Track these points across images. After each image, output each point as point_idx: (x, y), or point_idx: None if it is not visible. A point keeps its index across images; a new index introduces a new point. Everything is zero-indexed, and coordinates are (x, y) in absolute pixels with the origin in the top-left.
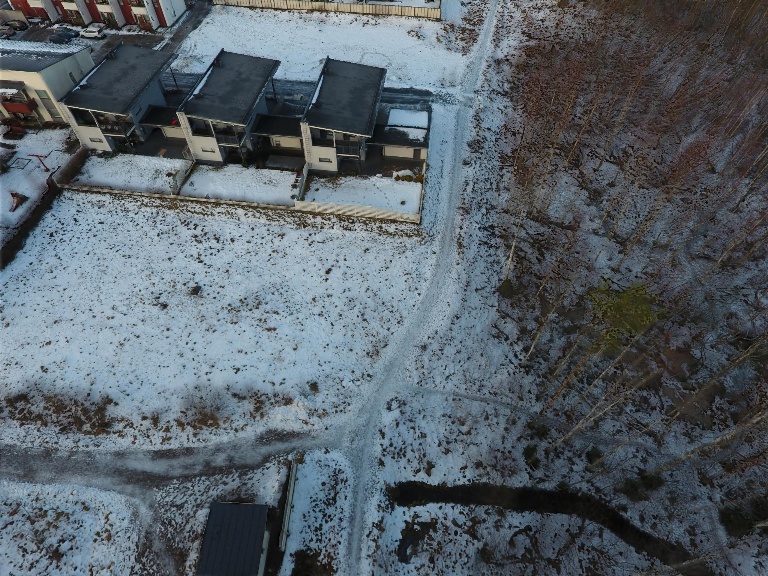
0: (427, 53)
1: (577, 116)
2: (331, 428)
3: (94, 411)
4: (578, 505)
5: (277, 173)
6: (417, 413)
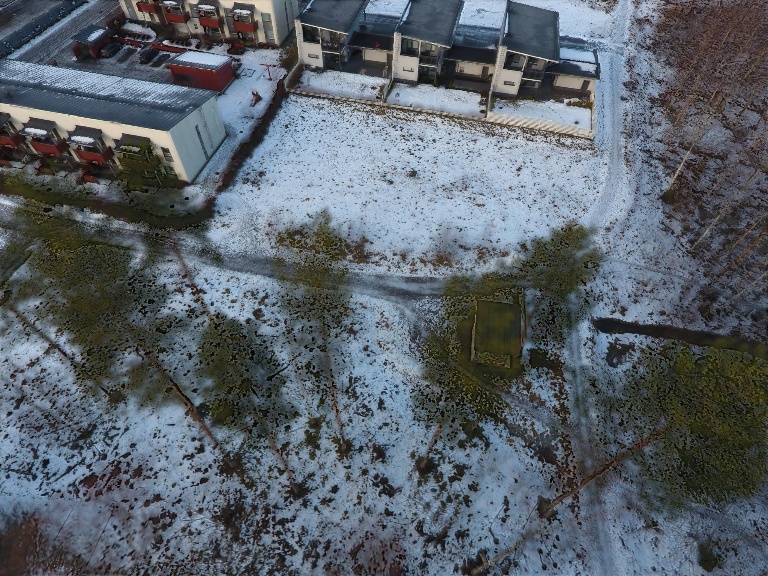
0: (573, 10)
1: (717, 70)
2: (542, 275)
3: (354, 247)
4: (748, 347)
5: (464, 93)
6: (608, 274)
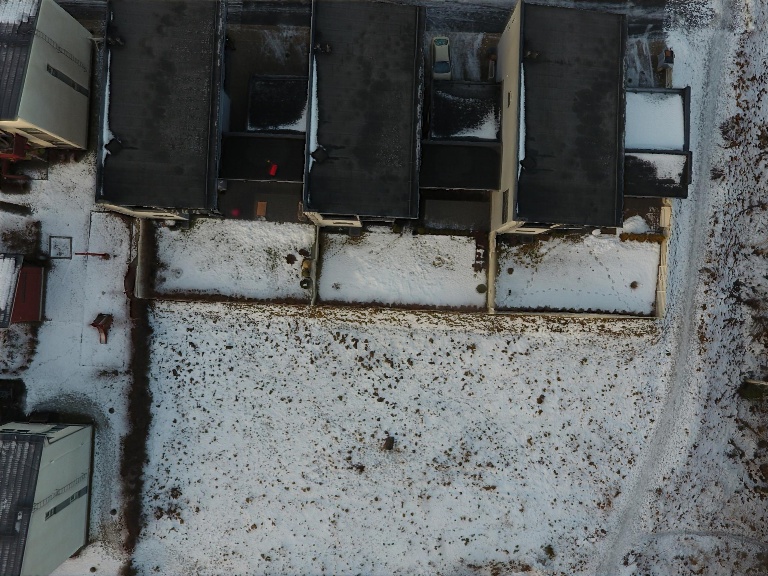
0: None
1: None
2: None
3: None
4: None
5: (447, 242)
6: (651, 560)
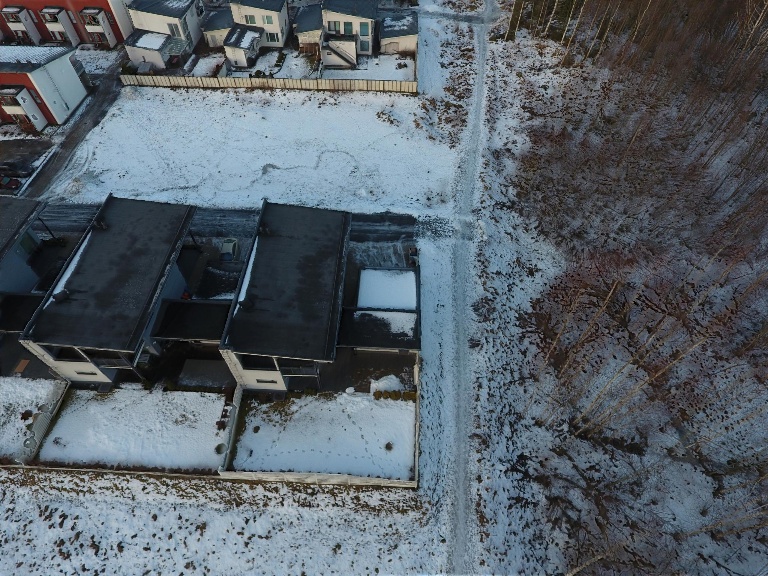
0: (404, 147)
1: (611, 237)
2: None
3: None
4: None
5: (195, 398)
6: None
